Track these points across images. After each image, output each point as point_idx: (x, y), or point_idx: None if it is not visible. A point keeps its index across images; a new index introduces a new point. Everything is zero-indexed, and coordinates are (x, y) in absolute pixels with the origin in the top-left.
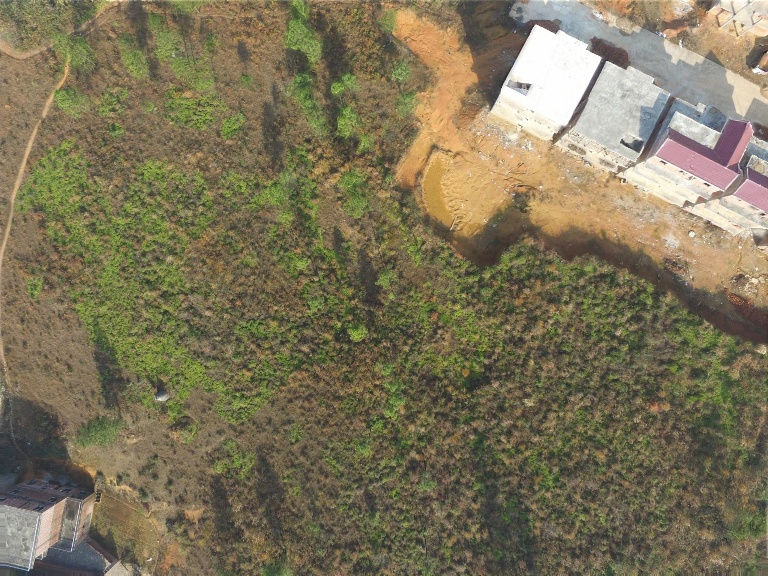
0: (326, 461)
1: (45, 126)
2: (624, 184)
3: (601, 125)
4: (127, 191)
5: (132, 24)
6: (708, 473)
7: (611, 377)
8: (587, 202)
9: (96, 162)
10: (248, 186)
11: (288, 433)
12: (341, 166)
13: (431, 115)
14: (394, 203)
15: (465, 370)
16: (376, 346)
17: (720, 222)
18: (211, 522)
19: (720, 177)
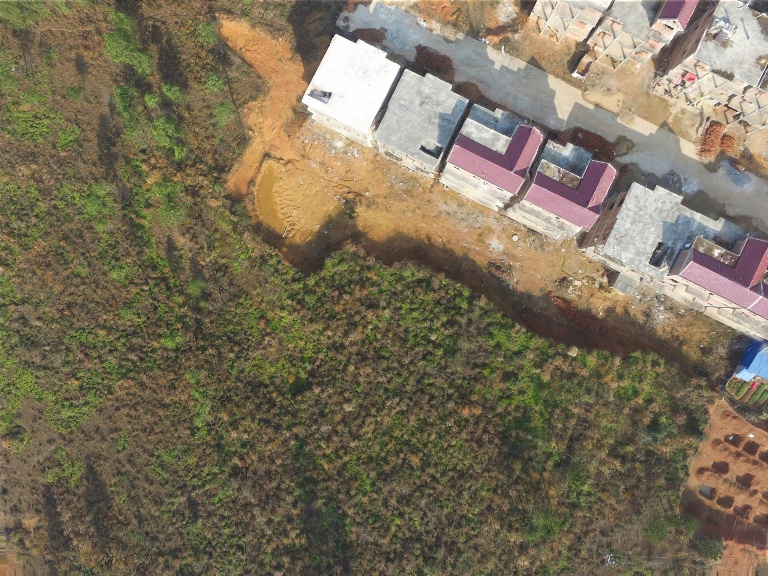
0: (151, 468)
1: None
2: (447, 189)
3: (400, 132)
4: None
5: None
6: (518, 475)
7: (427, 381)
8: (412, 207)
9: None
10: (81, 197)
11: (115, 441)
12: (174, 175)
13: (264, 124)
14: (225, 211)
15: (290, 376)
16: (202, 353)
17: (532, 226)
18: (44, 531)
19: (509, 182)
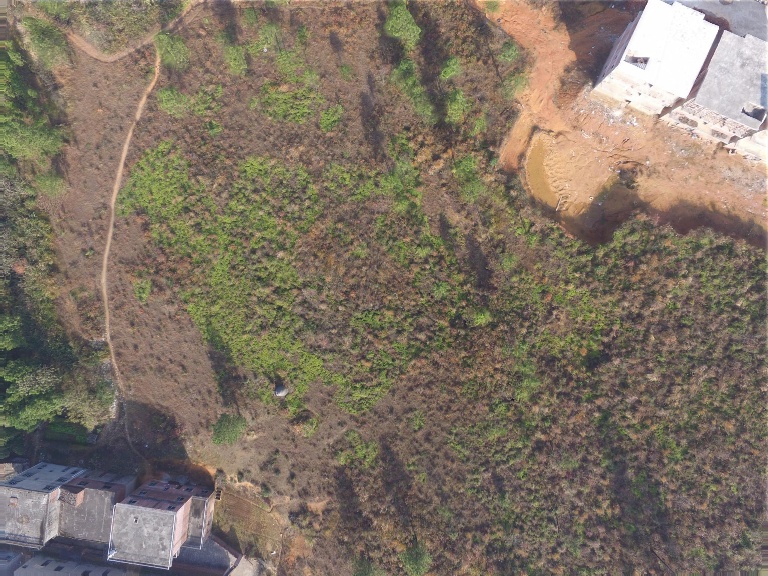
0: (451, 446)
1: (140, 128)
2: (732, 155)
3: (722, 95)
4: (231, 189)
5: (221, 20)
6: None
7: (734, 348)
8: (695, 175)
9: (197, 162)
10: (352, 177)
11: (411, 421)
12: (443, 152)
13: (530, 96)
14: (500, 186)
15: (583, 349)
16: (493, 330)
17: None
18: (336, 513)
19: None
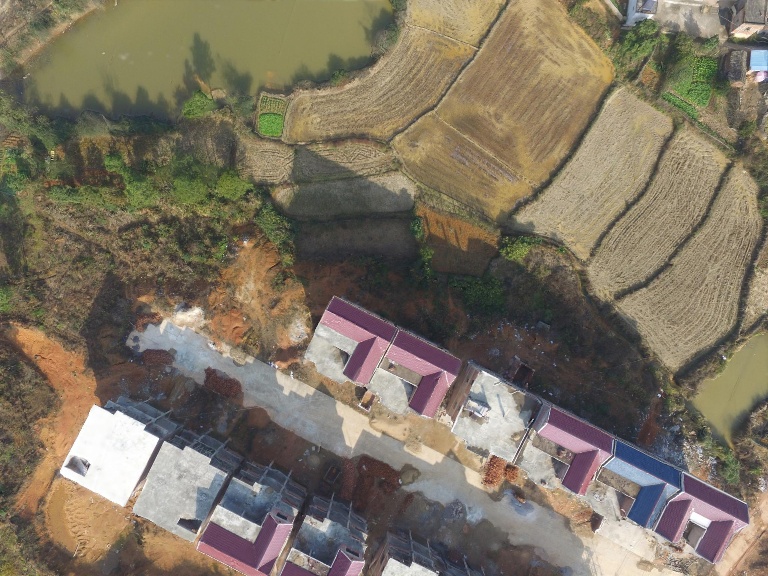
0: None
1: None
2: None
3: (158, 506)
4: None
5: None
6: None
7: None
8: (200, 535)
9: None
10: None
11: None
12: None
13: (56, 439)
14: (12, 534)
15: None
16: None
17: None
18: None
19: (256, 575)
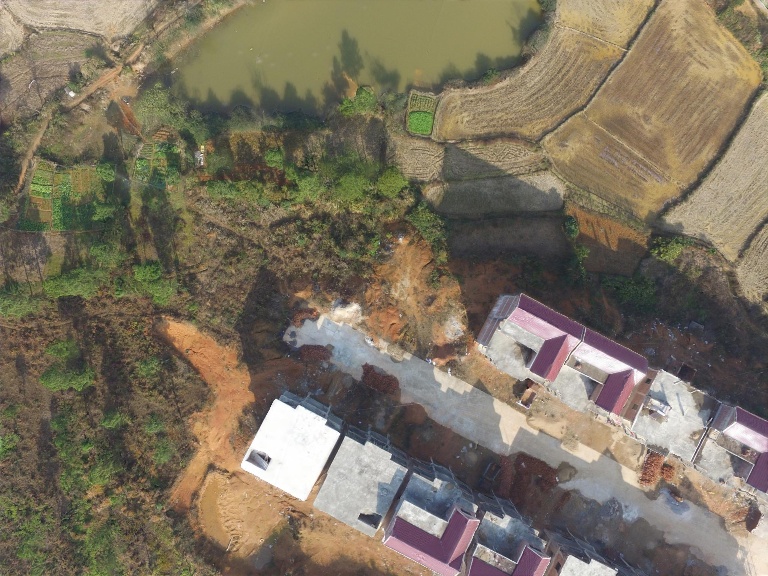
0: None
1: None
2: None
3: (339, 501)
4: None
5: None
6: None
7: None
8: (357, 531)
9: None
10: (18, 512)
11: None
12: (116, 487)
13: (209, 433)
14: (167, 528)
15: None
16: None
17: None
18: None
19: (444, 570)
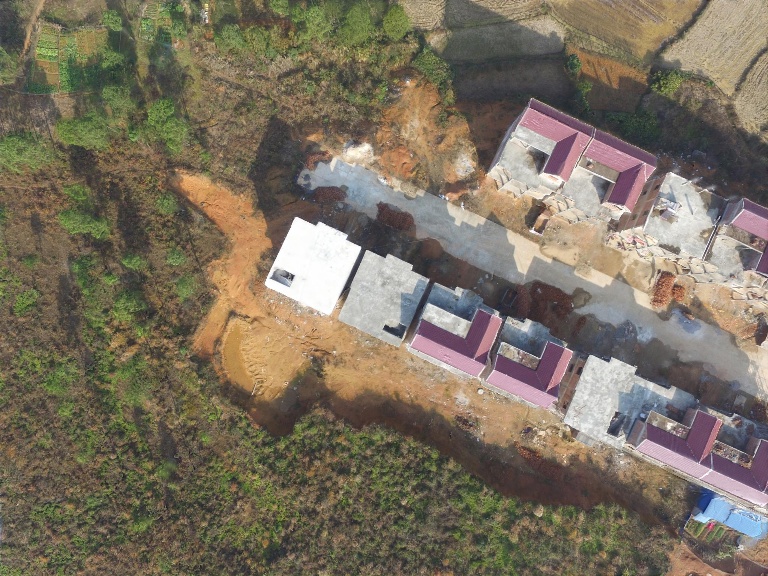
0: None
1: None
2: None
3: (364, 313)
4: None
5: None
6: None
7: (399, 546)
8: (380, 365)
9: None
10: (42, 365)
11: None
12: (138, 337)
13: (228, 281)
14: (192, 373)
15: (264, 541)
16: (174, 523)
17: None
18: None
19: (470, 367)
